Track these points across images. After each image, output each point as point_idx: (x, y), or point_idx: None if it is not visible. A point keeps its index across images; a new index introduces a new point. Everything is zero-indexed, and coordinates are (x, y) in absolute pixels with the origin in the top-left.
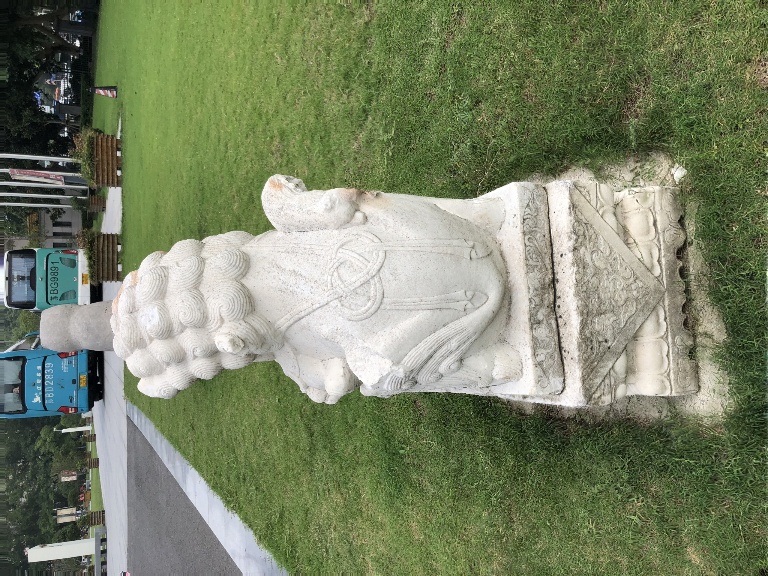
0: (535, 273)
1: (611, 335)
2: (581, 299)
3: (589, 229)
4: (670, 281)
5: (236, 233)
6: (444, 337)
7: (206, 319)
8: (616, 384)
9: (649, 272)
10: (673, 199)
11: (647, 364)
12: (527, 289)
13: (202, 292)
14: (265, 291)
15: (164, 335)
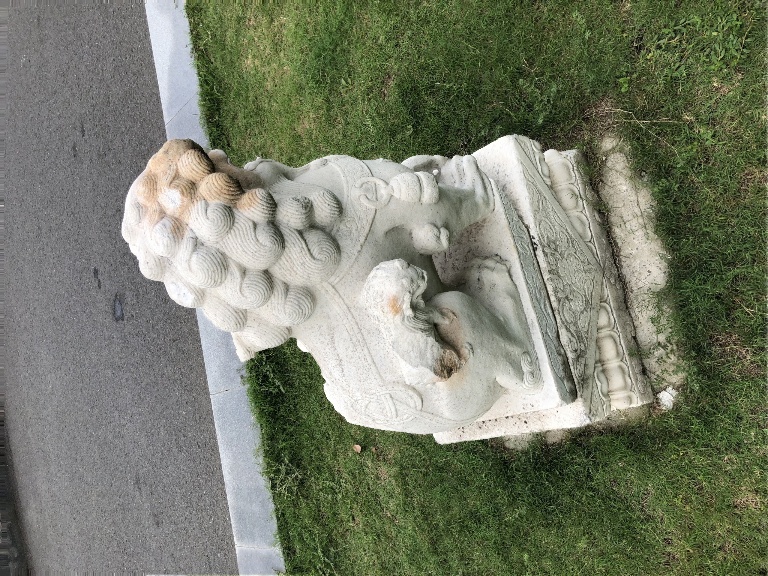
0: None
1: None
2: None
3: None
4: None
5: (324, 265)
6: None
7: None
8: None
9: None
10: None
11: None
12: None
13: (248, 314)
14: (305, 339)
15: None
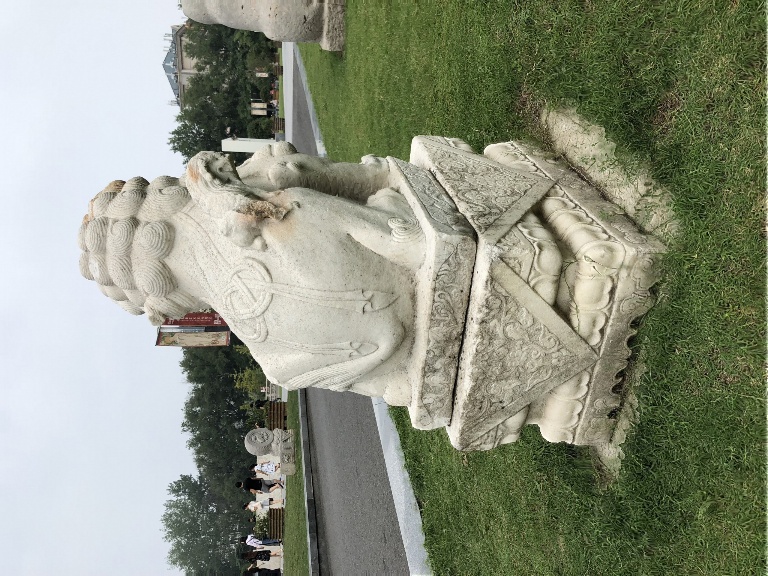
0: (440, 327)
1: (509, 397)
2: (479, 367)
3: (509, 302)
4: (610, 350)
5: (171, 196)
6: (326, 375)
7: (135, 287)
8: (504, 435)
9: (582, 341)
10: (651, 265)
11: (552, 417)
12: (426, 342)
13: (132, 261)
14: (184, 275)
15: (108, 285)
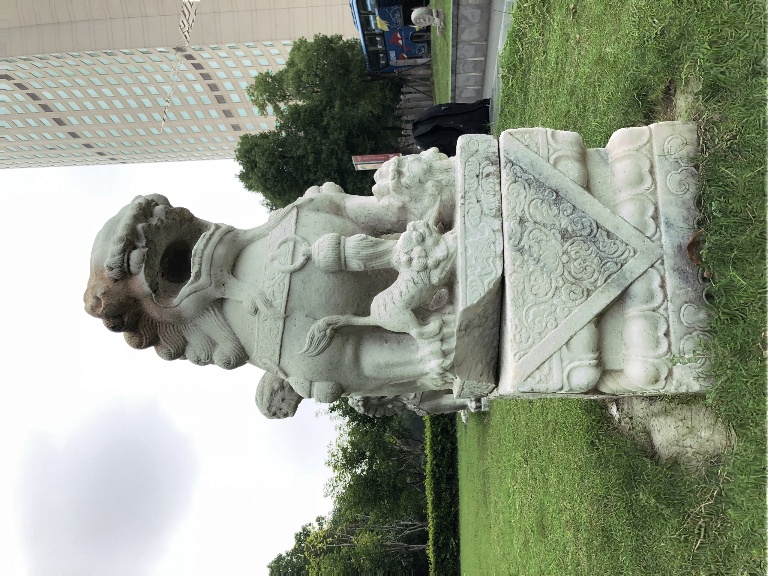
0: None
1: None
2: None
3: None
4: None
5: None
6: None
7: None
8: None
9: None
10: None
11: None
12: None
13: None
14: None
15: None
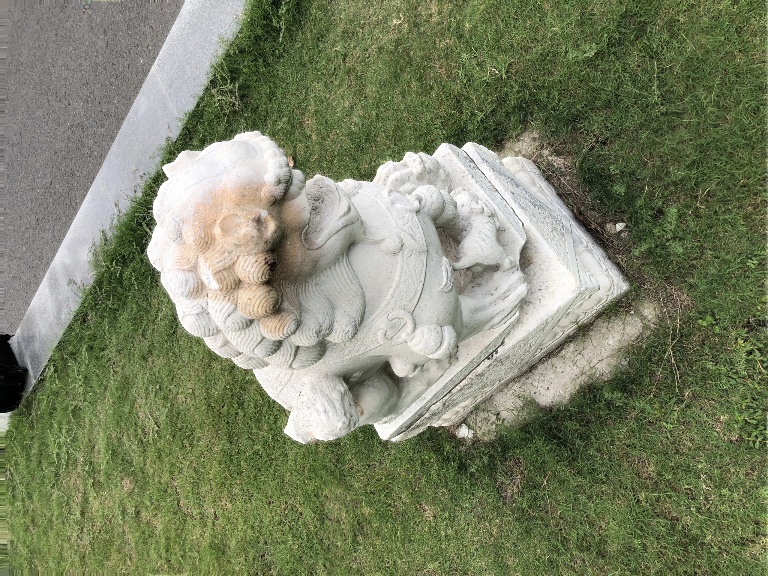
0: None
1: None
2: None
3: None
4: None
5: None
6: None
7: None
8: None
9: None
10: None
11: None
12: None
13: None
14: None
15: None
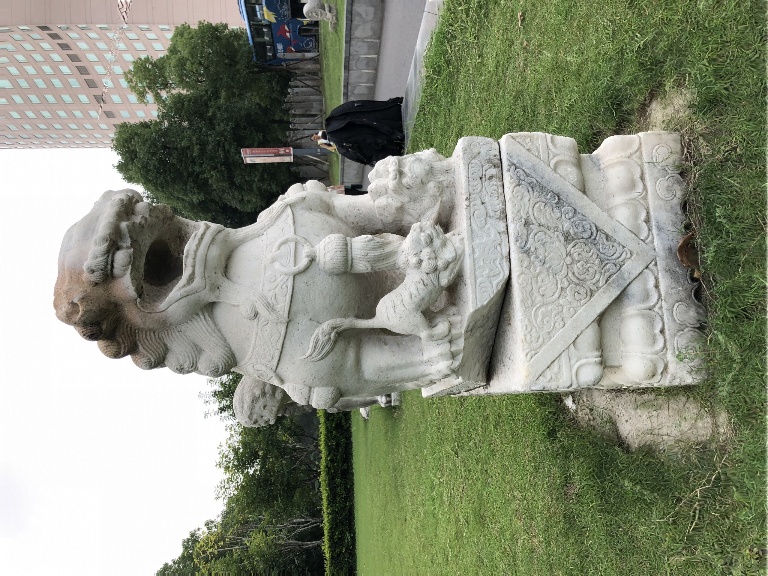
0: None
1: None
2: None
3: None
4: None
5: None
6: None
7: None
8: None
9: None
10: None
11: None
12: None
13: None
14: None
15: None
